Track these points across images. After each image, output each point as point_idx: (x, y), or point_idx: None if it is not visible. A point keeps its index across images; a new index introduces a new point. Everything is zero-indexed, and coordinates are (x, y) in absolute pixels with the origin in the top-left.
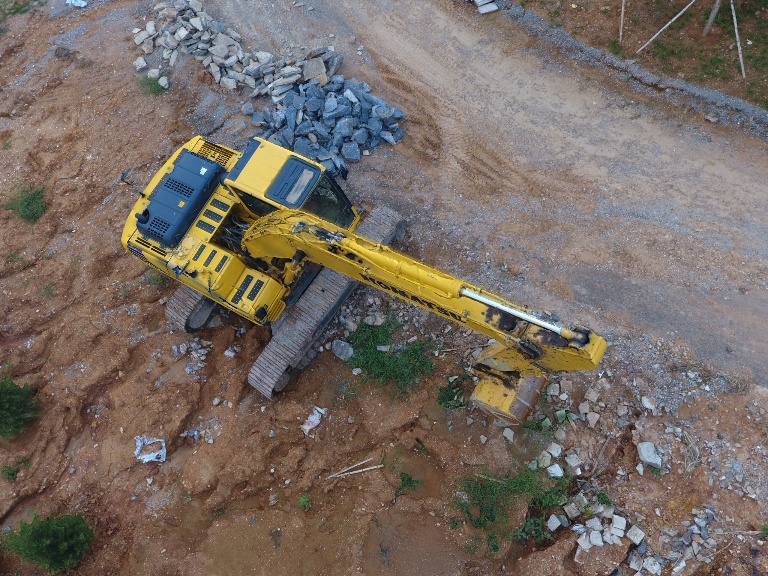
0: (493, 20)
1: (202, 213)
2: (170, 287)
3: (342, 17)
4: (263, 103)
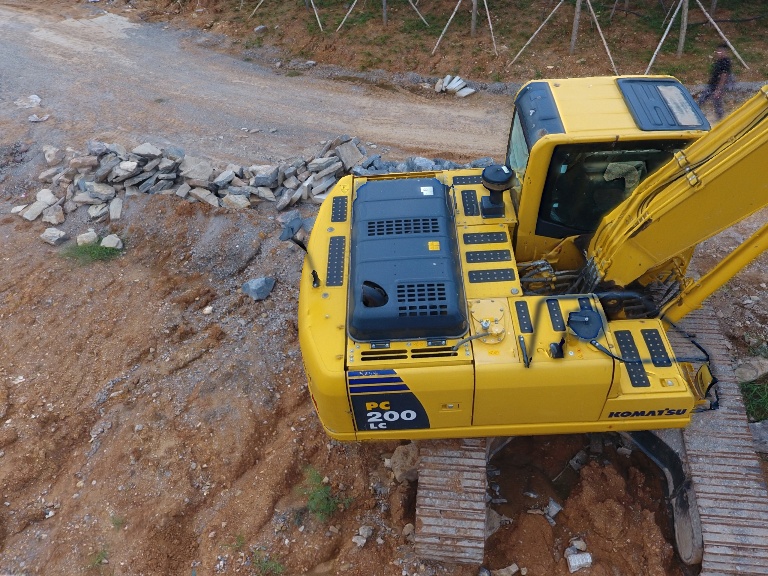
0: (480, 98)
1: (464, 260)
2: (347, 510)
3: (317, 129)
4: (300, 212)
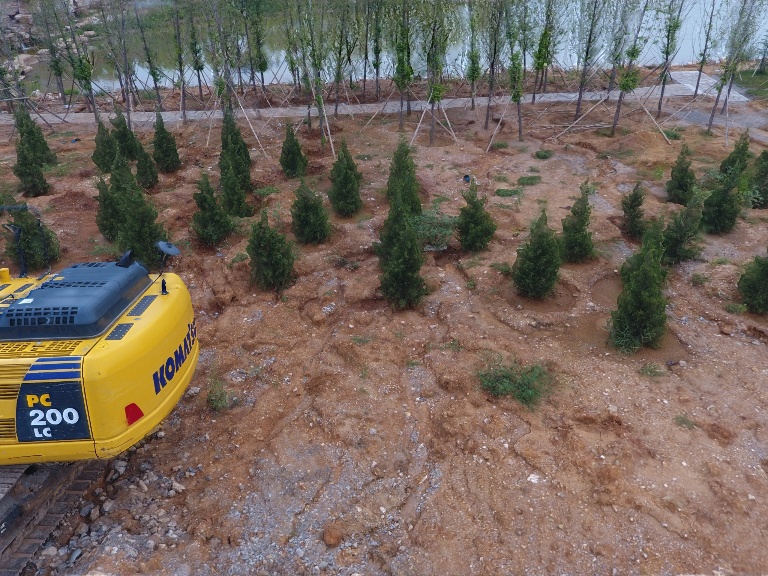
0: None
1: None
2: None
3: None
4: None
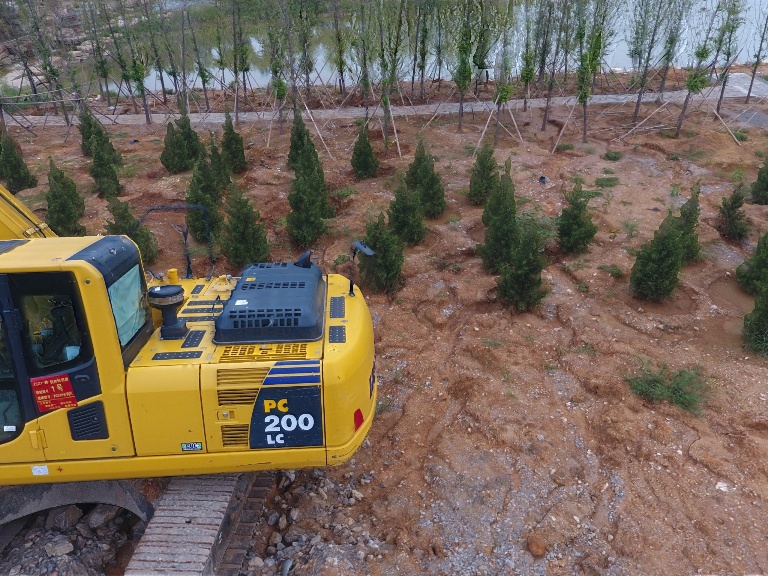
0: None
1: None
2: None
3: None
4: None
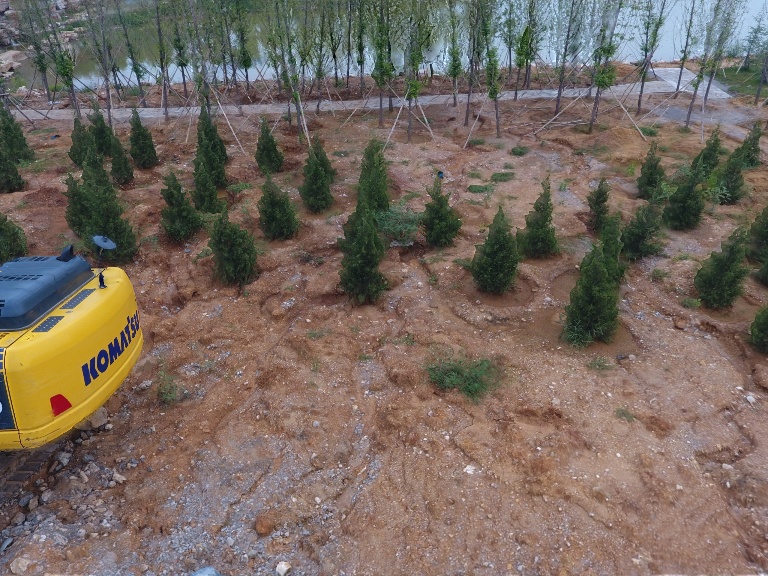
0: None
1: None
2: None
3: None
4: None
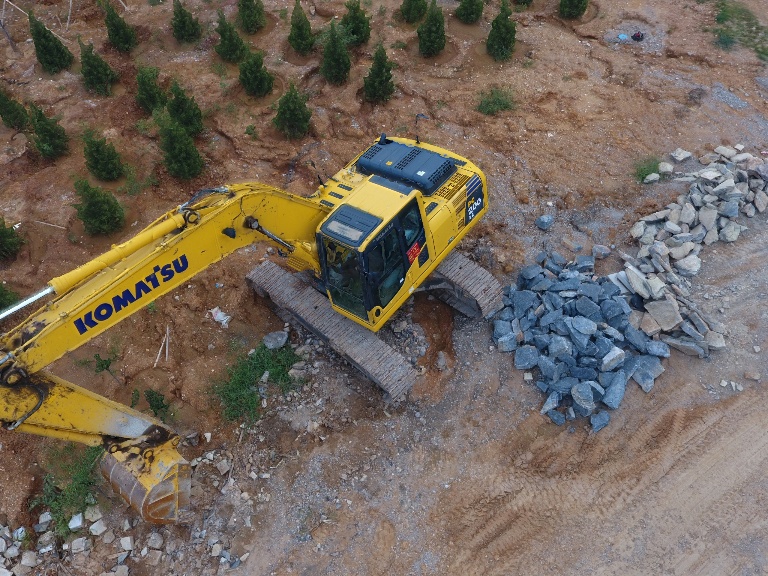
0: None
1: None
2: None
3: None
4: (615, 267)
